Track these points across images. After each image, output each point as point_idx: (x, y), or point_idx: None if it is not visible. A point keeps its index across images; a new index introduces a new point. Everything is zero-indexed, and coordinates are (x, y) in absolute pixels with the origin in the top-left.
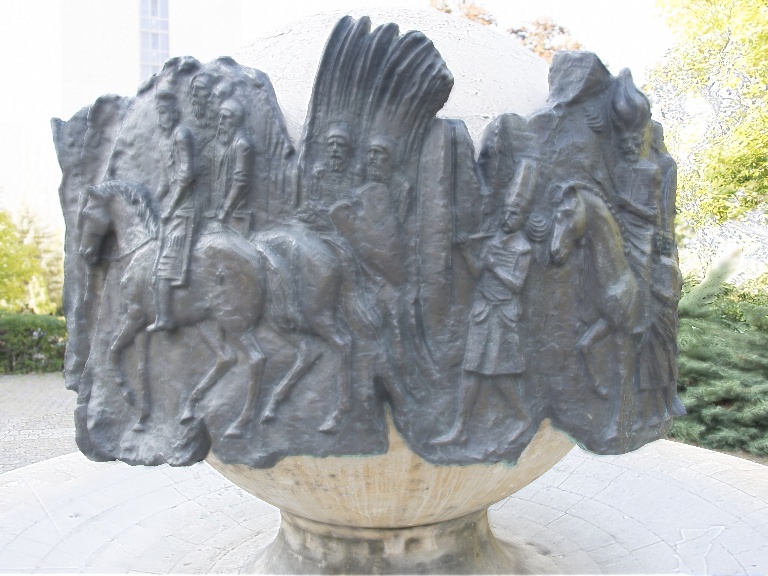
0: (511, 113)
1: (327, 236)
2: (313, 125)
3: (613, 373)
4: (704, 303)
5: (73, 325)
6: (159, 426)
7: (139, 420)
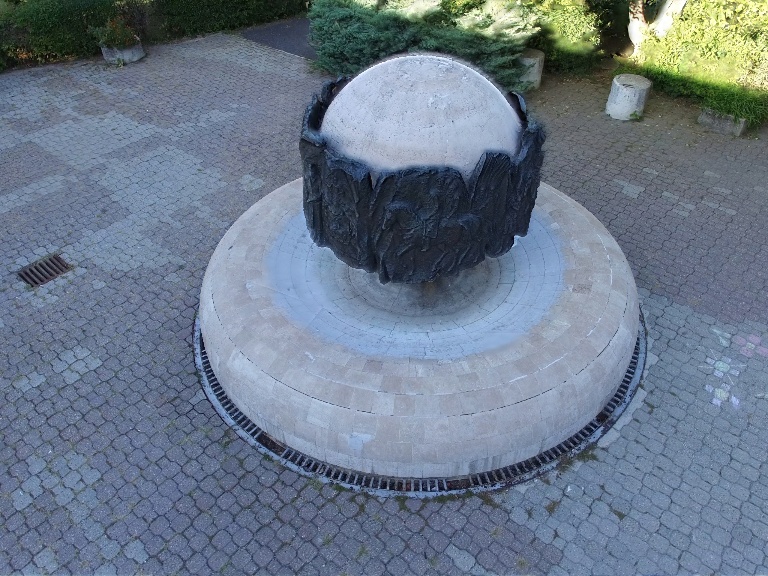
0: (519, 161)
1: (479, 216)
2: (476, 187)
3: (529, 215)
4: (434, 5)
5: (365, 246)
6: (421, 273)
7: (412, 272)
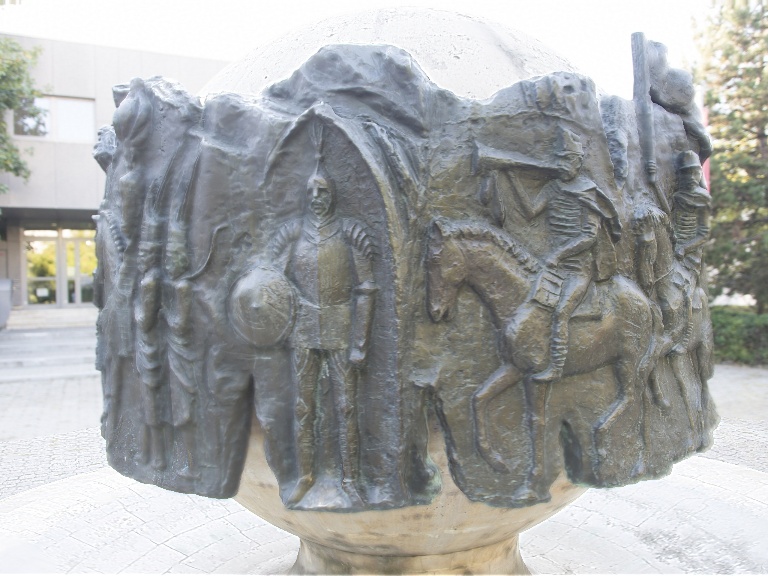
0: None
1: None
2: None
3: None
4: None
5: None
6: None
7: None
